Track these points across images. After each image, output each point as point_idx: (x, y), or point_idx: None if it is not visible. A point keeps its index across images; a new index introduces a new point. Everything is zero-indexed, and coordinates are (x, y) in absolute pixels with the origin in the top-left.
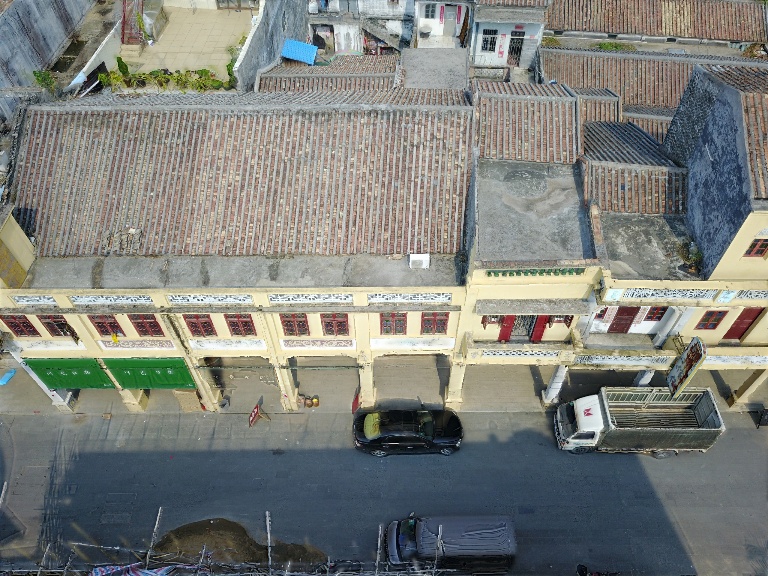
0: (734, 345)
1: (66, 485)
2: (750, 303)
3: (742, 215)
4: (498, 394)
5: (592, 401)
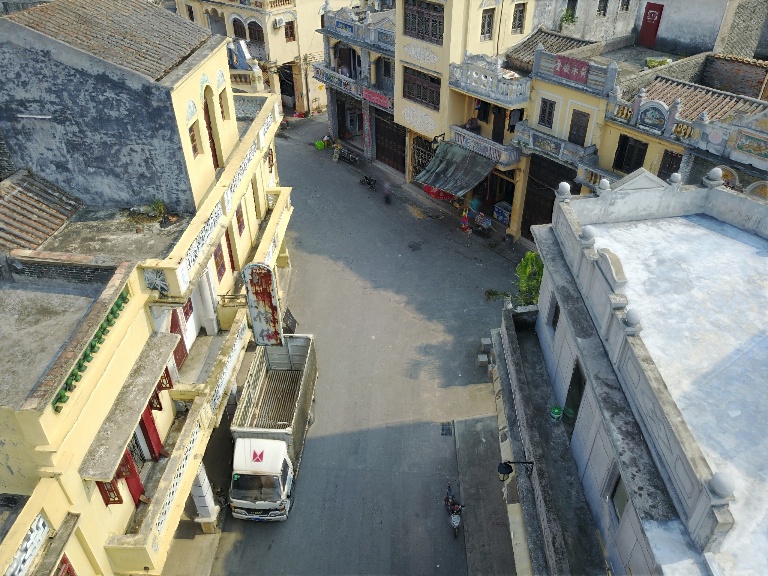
0: None
1: None
2: (238, 197)
3: (163, 108)
4: None
5: (244, 447)
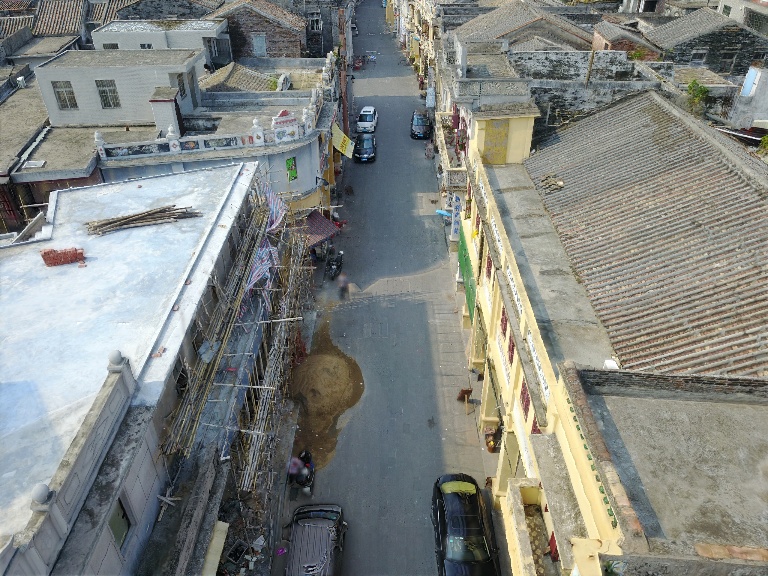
0: None
1: (395, 302)
2: None
3: None
4: None
5: None
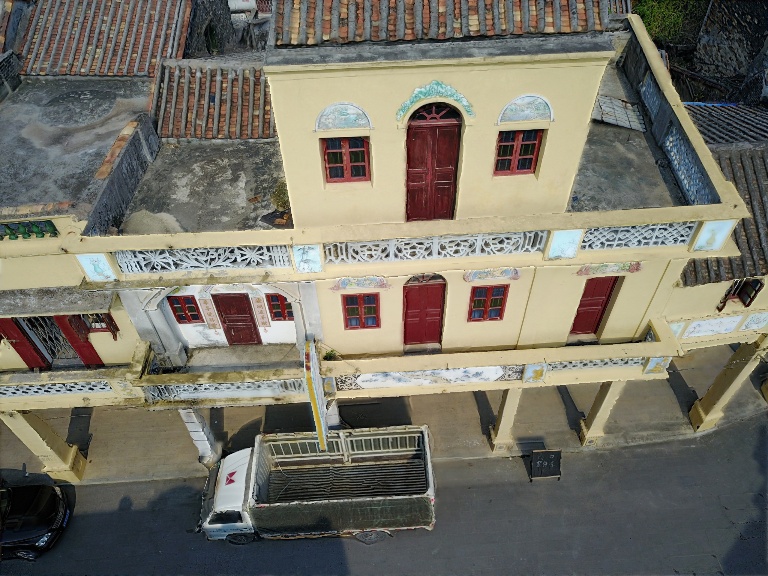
0: (432, 353)
1: None
2: (363, 270)
3: None
4: (148, 452)
5: (241, 459)
